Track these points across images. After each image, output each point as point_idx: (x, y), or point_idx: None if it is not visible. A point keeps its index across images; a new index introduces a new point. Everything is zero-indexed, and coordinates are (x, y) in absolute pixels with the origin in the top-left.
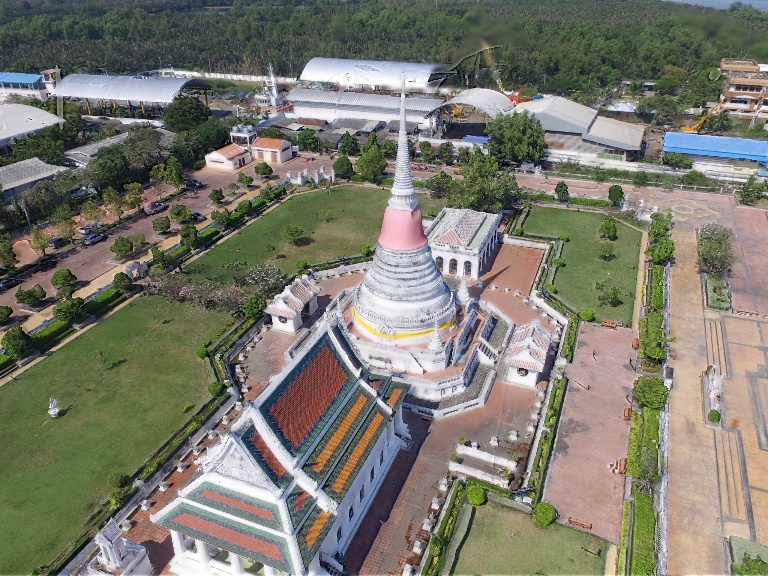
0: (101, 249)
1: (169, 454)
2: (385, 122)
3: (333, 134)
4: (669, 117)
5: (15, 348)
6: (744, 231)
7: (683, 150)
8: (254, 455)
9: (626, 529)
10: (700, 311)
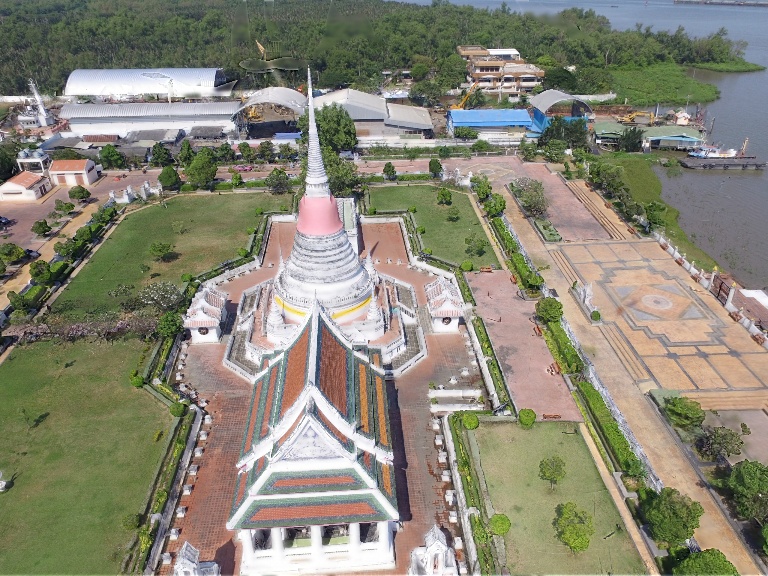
0: None
1: (171, 481)
2: (183, 130)
3: (136, 148)
4: (437, 99)
5: None
6: (538, 181)
7: (469, 124)
8: (325, 429)
9: (584, 409)
10: (542, 246)
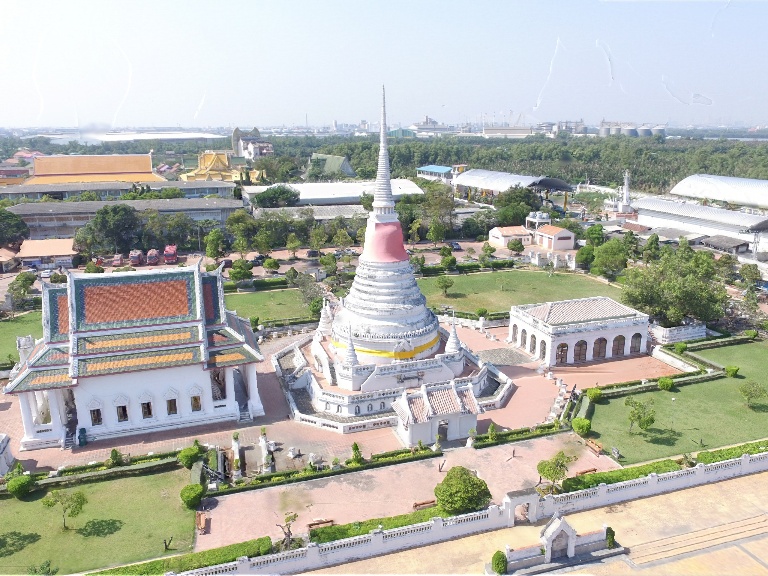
0: None
1: None
2: None
3: None
4: None
5: None
6: None
7: None
8: (52, 307)
9: None
10: None
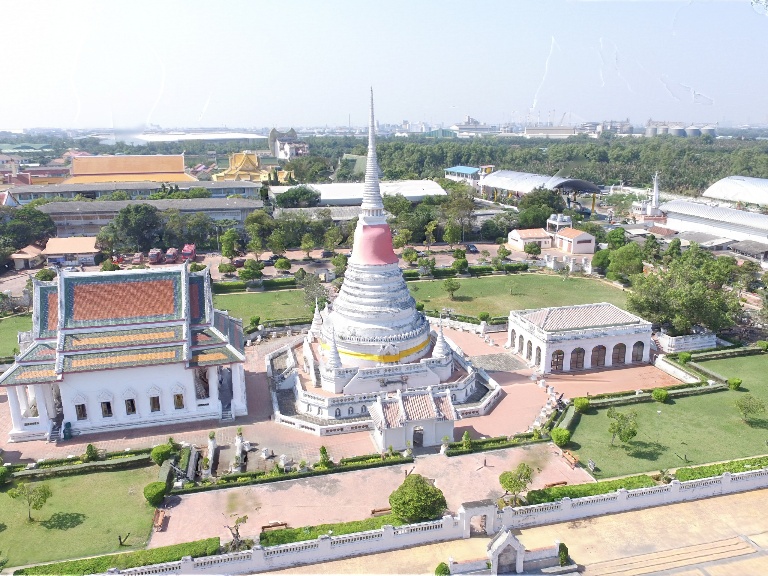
0: None
1: None
2: None
3: None
4: None
5: None
6: None
7: None
8: (43, 304)
9: None
10: (760, 527)
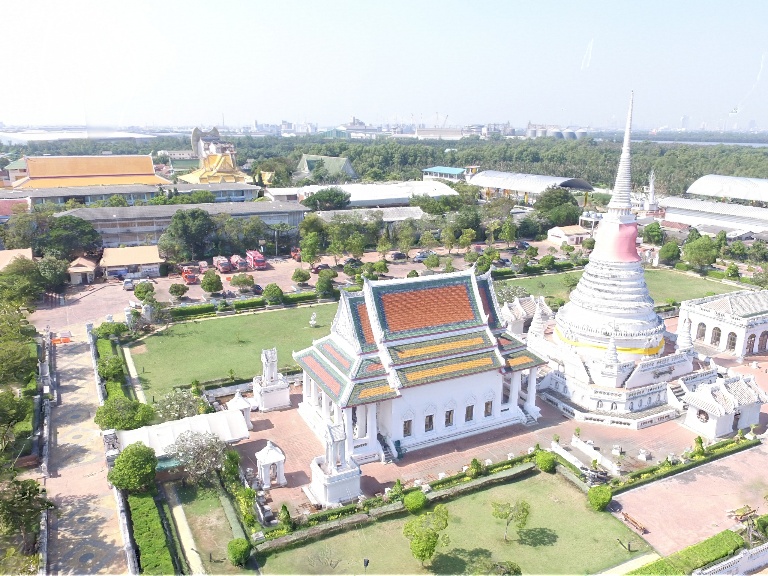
0: (422, 265)
1: None
2: None
3: (685, 233)
4: None
5: (320, 288)
6: None
7: None
8: (354, 316)
9: None
10: None
